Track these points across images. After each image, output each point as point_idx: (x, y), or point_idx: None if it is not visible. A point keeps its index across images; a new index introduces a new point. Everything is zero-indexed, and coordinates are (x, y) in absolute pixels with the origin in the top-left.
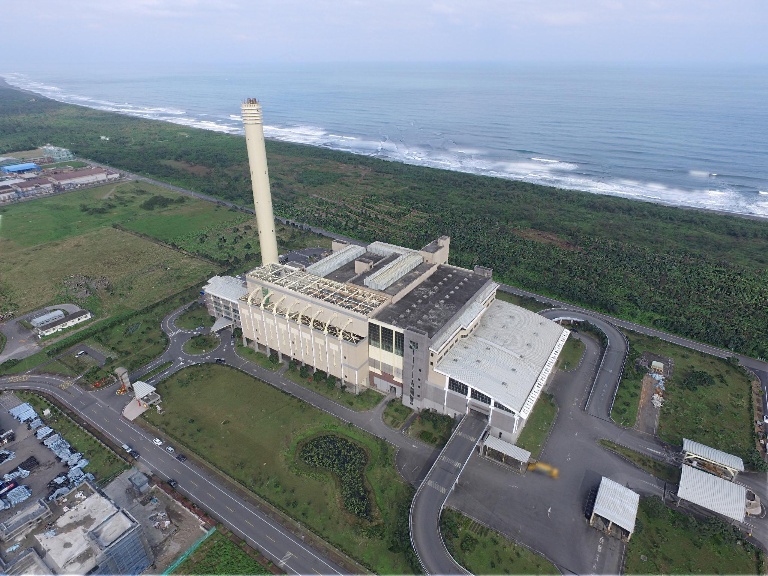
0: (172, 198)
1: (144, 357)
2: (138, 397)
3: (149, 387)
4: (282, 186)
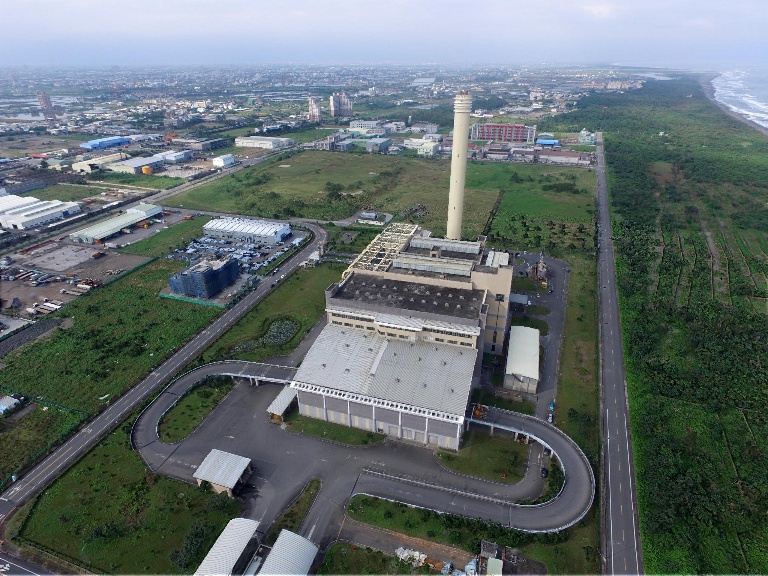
0: (574, 188)
1: (349, 249)
2: (310, 257)
3: (317, 257)
4: (694, 213)
